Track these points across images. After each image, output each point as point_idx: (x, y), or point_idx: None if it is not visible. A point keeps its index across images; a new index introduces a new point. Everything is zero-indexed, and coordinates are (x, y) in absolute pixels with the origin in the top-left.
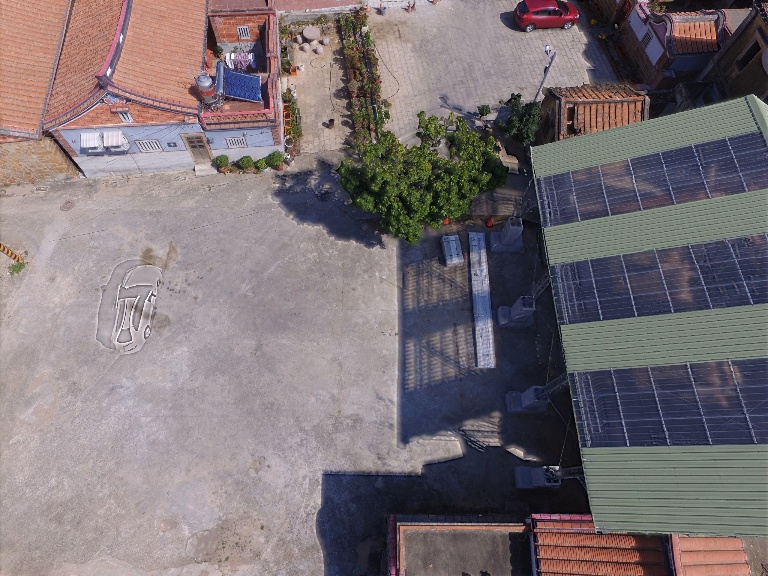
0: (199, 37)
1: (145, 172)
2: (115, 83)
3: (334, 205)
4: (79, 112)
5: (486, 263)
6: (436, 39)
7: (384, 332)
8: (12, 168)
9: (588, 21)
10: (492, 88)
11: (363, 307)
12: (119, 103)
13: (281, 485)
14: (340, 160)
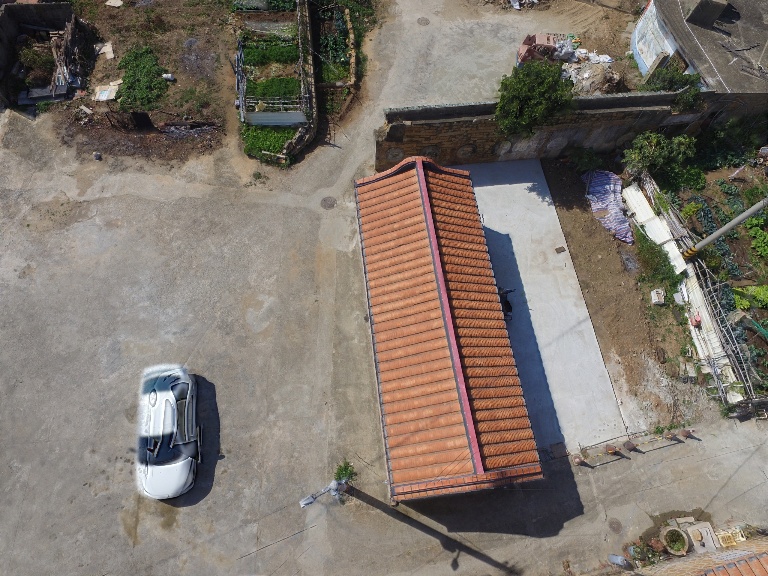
0: None
1: None
2: None
3: None
4: None
5: None
6: None
7: None
8: None
9: None
10: None
11: None
12: None
13: (5, 256)
14: None
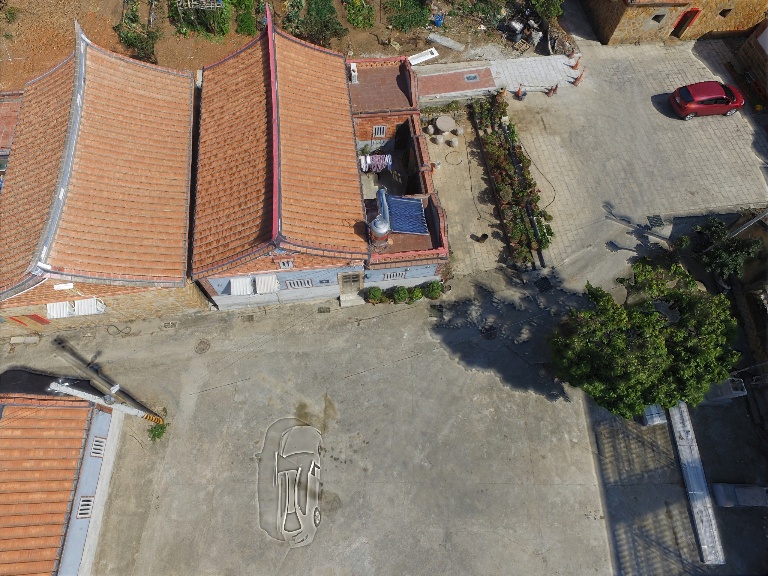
0: (351, 155)
1: (284, 303)
2: (287, 238)
3: (503, 344)
4: (239, 265)
5: (690, 422)
6: (586, 130)
7: (587, 515)
8: (143, 308)
9: (750, 105)
10: (659, 193)
11: (558, 481)
12: (284, 254)
13: None
14: (500, 285)
